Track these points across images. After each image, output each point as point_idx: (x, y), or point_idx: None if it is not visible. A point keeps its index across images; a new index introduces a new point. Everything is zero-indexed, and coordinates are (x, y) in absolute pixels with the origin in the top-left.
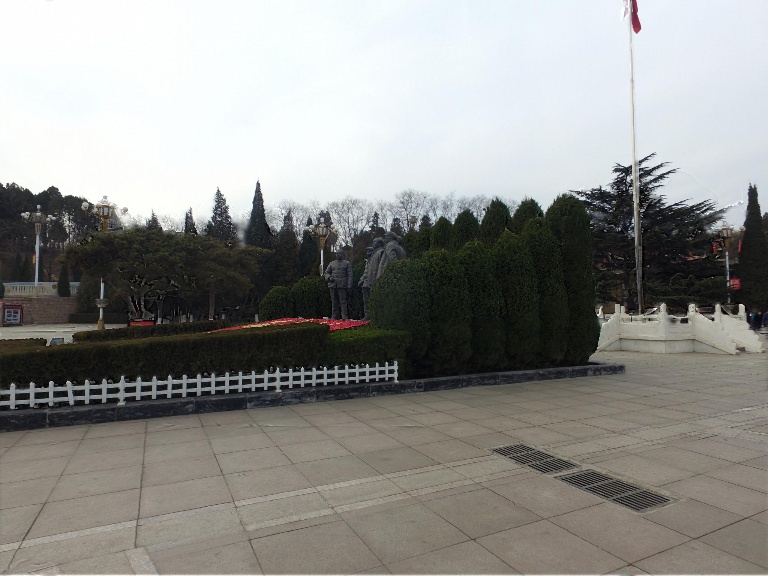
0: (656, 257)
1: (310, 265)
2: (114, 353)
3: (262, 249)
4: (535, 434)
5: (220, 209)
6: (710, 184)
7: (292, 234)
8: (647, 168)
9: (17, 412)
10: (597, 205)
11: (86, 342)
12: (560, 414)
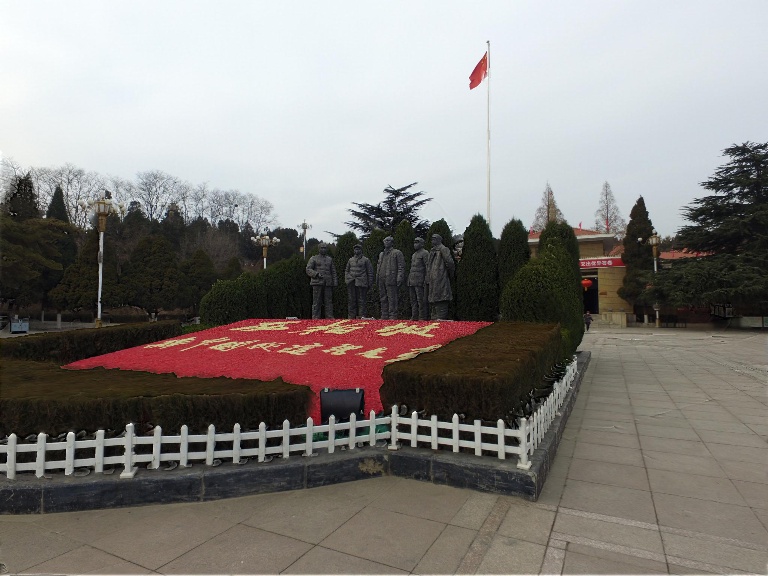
0: None
1: None
2: (536, 359)
3: None
4: (764, 394)
5: None
6: (452, 214)
7: (32, 205)
8: (409, 193)
9: (546, 436)
10: (373, 219)
11: None
12: (710, 383)
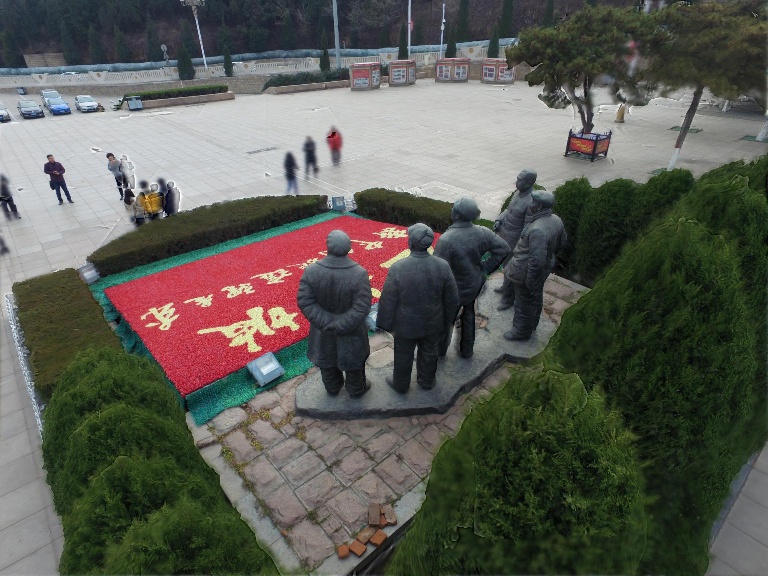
0: None
1: None
2: None
3: None
4: None
5: None
6: None
7: None
8: None
9: None
10: None
11: (360, 203)
12: None
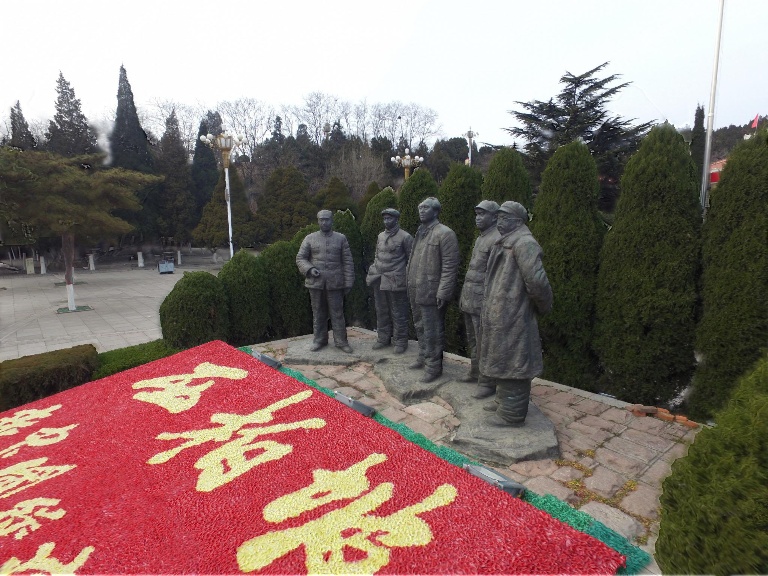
0: (603, 182)
1: (208, 186)
2: None
3: (143, 175)
4: None
5: (66, 104)
6: (660, 102)
7: (179, 144)
8: (597, 79)
9: None
10: (543, 120)
11: None
12: None
